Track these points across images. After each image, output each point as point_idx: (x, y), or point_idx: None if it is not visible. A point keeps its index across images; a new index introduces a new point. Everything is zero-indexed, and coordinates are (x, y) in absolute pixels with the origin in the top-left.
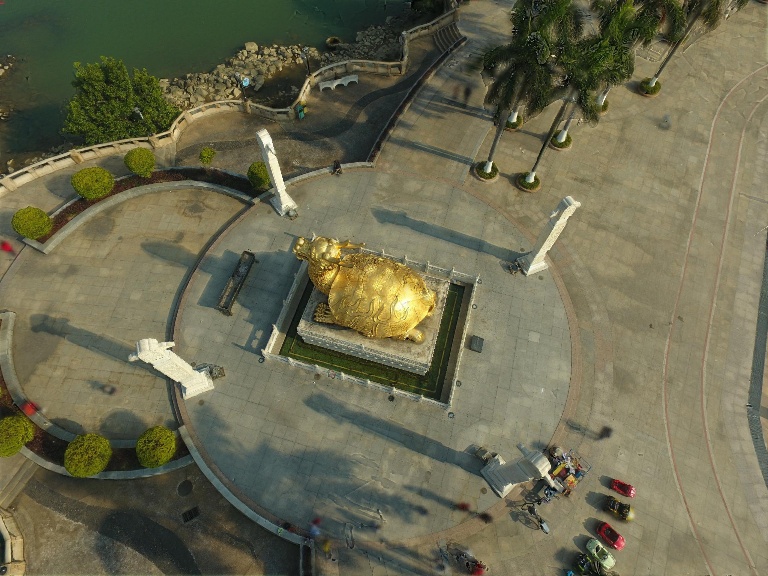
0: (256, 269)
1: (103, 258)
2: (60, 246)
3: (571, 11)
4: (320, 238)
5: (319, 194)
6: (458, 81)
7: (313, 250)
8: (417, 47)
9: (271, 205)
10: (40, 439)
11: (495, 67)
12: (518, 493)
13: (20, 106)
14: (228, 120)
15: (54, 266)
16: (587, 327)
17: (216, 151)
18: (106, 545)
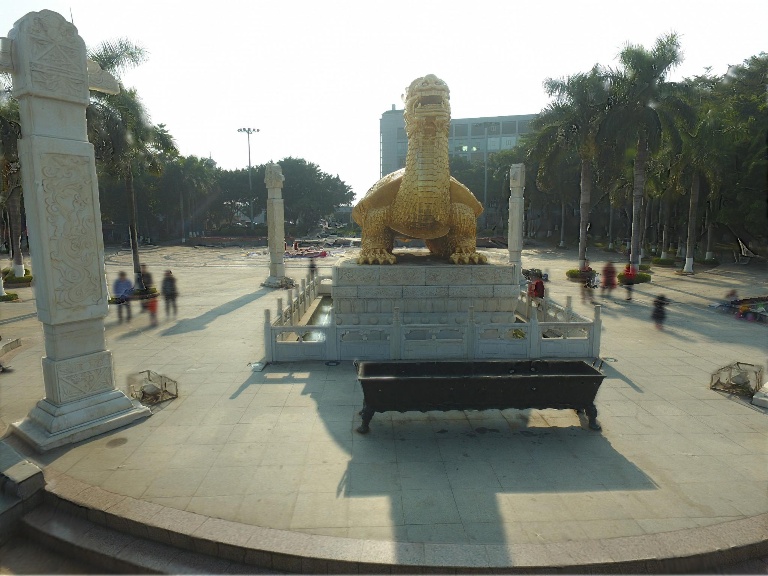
0: None
1: None
2: None
3: None
4: None
5: None
6: None
7: None
8: None
9: (76, 444)
10: None
11: None
12: None
13: None
14: None
15: None
16: None
17: None
18: None
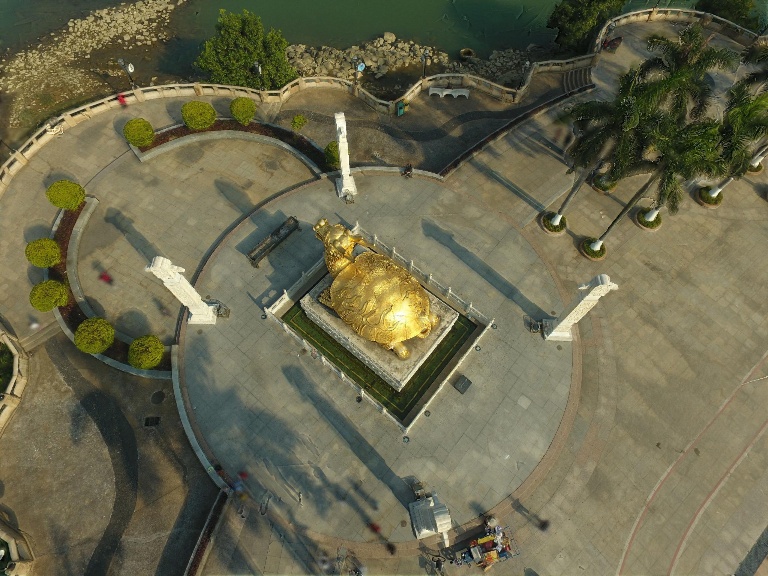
0: (296, 236)
1: (181, 181)
2: (154, 159)
3: (698, 87)
4: (339, 226)
5: (381, 189)
6: (566, 126)
7: (328, 234)
8: (542, 81)
9: (335, 184)
10: (71, 308)
11: (587, 121)
12: (435, 542)
13: (182, 35)
14: (335, 97)
15: (143, 174)
16: (586, 416)
17: (313, 121)
18: (81, 415)
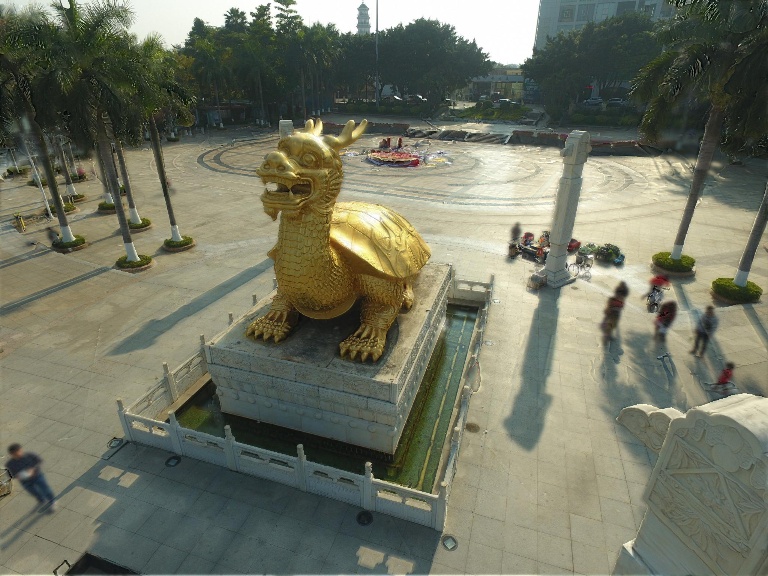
0: None
1: None
2: None
3: None
4: None
5: None
6: None
7: (314, 140)
8: None
9: None
10: None
11: (57, 91)
12: None
13: None
14: None
15: None
16: None
17: None
18: None
